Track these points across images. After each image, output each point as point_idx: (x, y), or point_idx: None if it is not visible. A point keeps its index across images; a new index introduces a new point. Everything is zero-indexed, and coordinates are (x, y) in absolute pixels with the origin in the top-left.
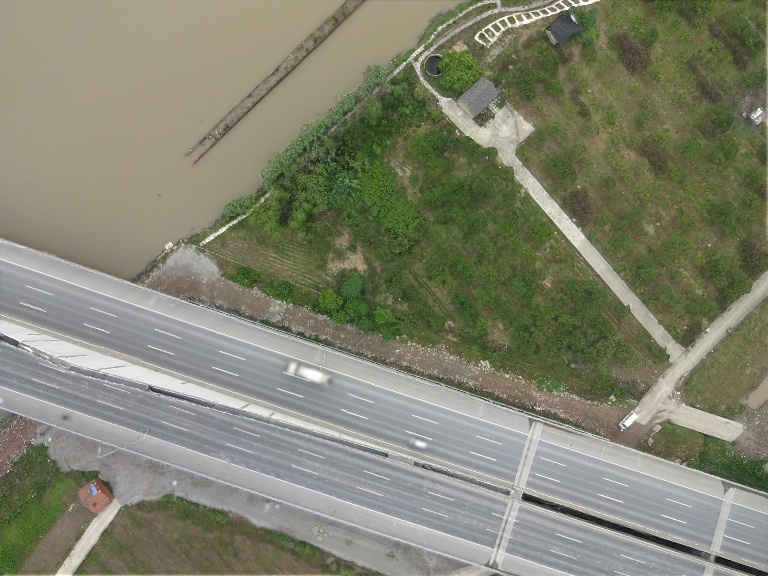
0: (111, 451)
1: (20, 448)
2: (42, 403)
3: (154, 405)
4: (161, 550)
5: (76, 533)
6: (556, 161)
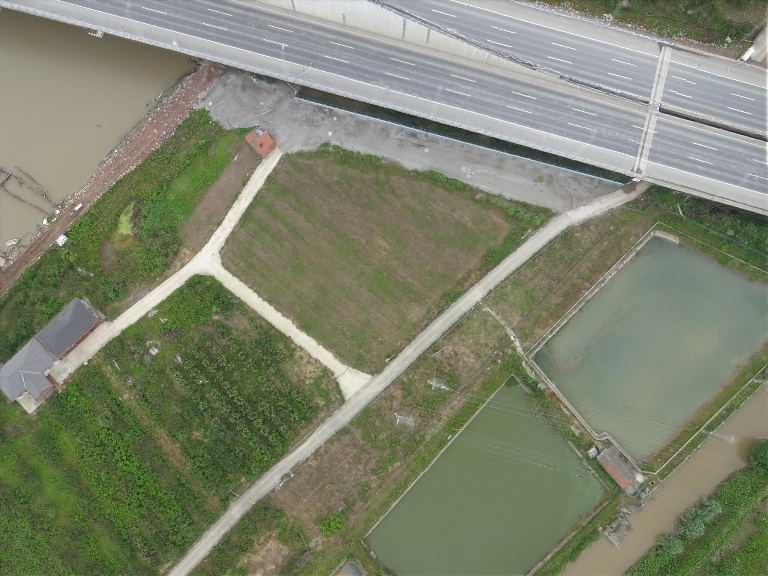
0: (268, 110)
1: (183, 113)
2: (213, 44)
3: (316, 42)
4: (322, 191)
5: (242, 179)
6: None
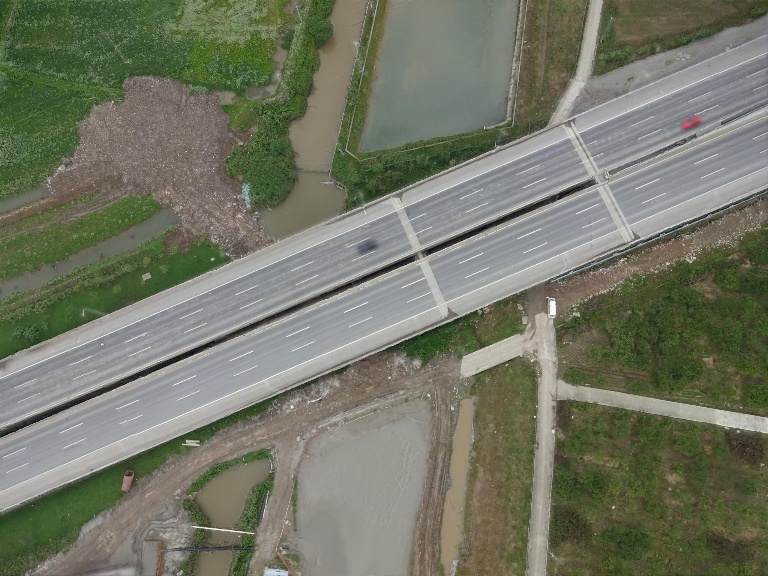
0: None
1: None
2: None
3: None
4: None
5: None
6: None
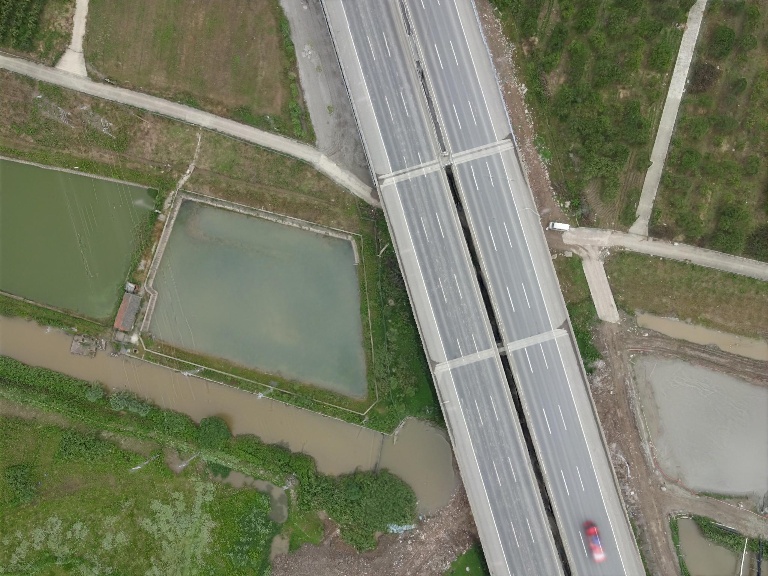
0: None
1: None
2: None
3: None
4: None
5: None
6: (727, 30)
